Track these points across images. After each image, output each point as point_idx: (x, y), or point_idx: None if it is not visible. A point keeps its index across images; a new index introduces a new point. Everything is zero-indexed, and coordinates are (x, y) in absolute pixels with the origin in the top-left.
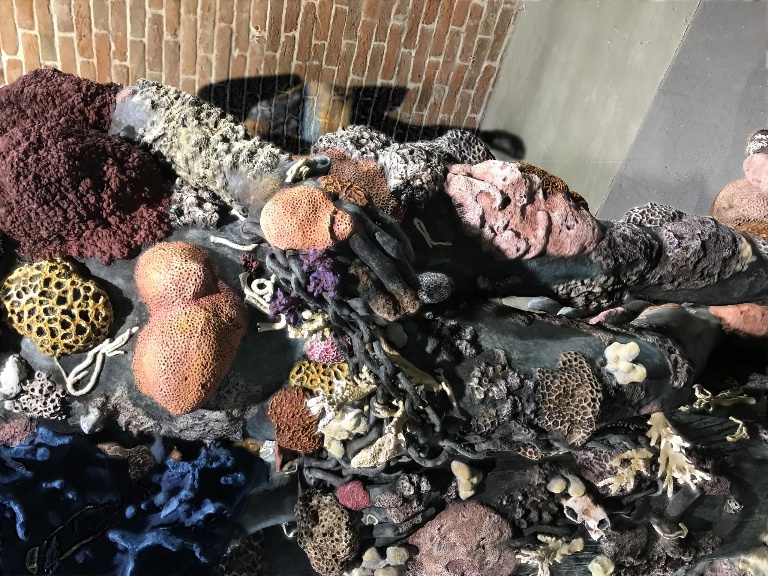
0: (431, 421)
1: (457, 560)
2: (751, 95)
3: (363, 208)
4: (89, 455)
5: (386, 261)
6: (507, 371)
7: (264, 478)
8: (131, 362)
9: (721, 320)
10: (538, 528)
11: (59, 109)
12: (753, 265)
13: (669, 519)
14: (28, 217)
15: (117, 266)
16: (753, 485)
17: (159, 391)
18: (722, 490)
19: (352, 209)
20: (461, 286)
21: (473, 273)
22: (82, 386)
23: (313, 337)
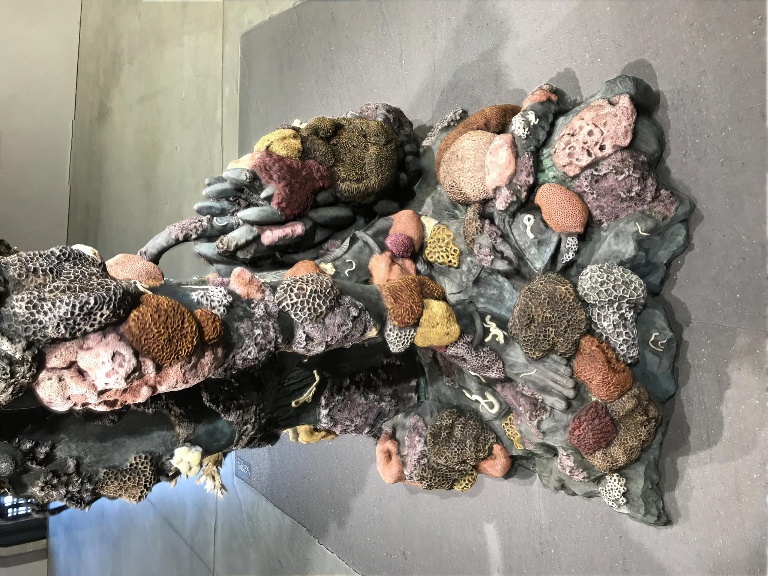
0: None
1: None
2: (597, 6)
3: None
4: None
5: None
6: (73, 477)
7: None
8: None
9: (371, 277)
10: None
11: None
12: None
13: None
14: None
15: None
16: None
17: None
18: None
19: None
20: None
21: None
22: None
23: None
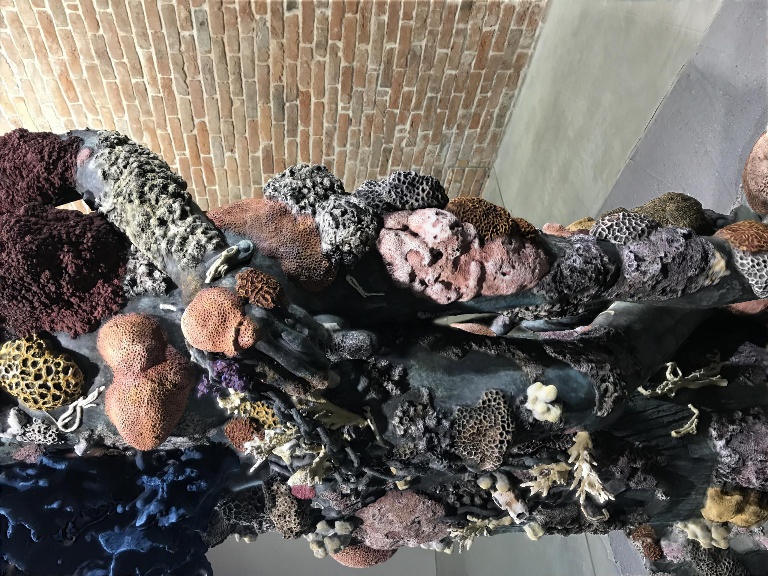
0: (351, 458)
1: (395, 531)
2: None
3: (271, 310)
4: (83, 472)
5: (291, 358)
6: (428, 410)
7: (234, 467)
8: (104, 410)
9: None
10: (469, 509)
11: (27, 181)
12: (726, 278)
13: (595, 504)
14: (4, 306)
15: (82, 339)
16: (688, 476)
17: (124, 438)
18: (647, 487)
19: (259, 315)
20: (402, 319)
21: (412, 310)
22: (70, 425)
23: (235, 413)
